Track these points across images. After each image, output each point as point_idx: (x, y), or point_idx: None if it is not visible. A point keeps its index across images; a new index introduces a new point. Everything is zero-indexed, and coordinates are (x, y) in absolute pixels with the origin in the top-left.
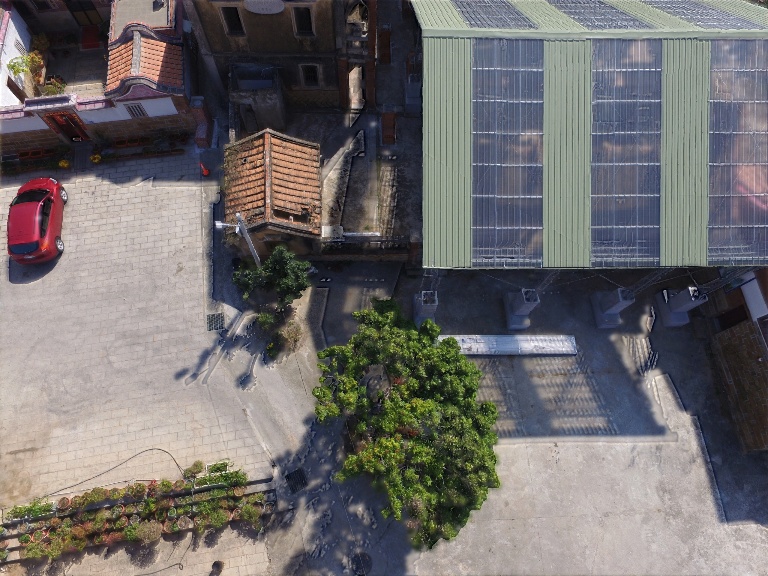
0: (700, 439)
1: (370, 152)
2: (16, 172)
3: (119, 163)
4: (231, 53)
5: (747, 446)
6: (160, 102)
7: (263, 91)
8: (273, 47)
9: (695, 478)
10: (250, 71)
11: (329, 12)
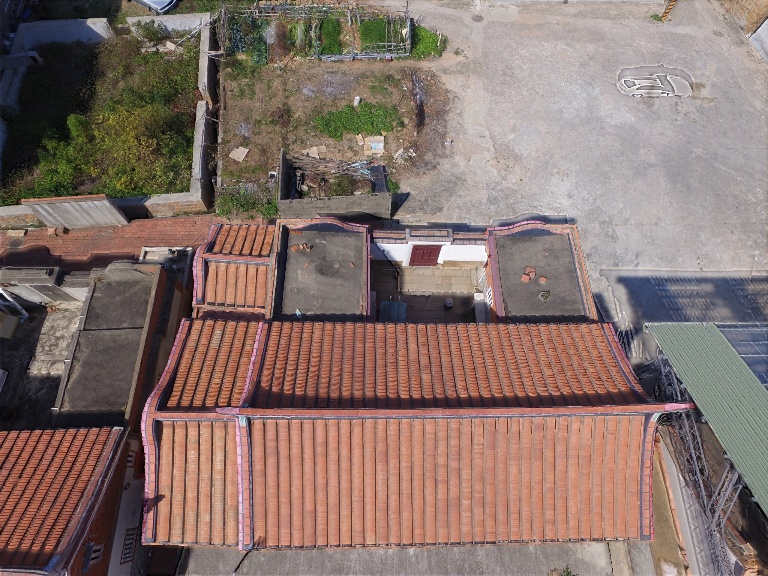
0: None
1: None
2: None
3: None
4: None
5: None
6: None
7: None
8: None
9: (588, 244)
10: None
11: None
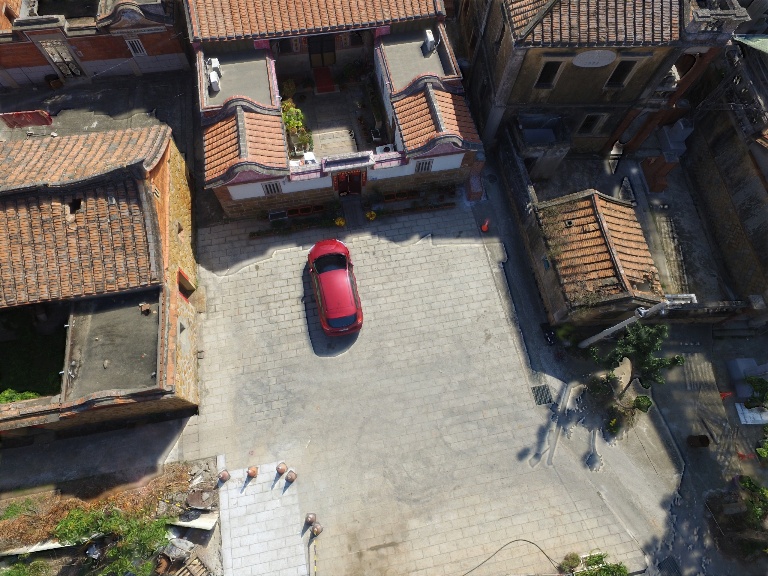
0: None
1: (641, 201)
2: (289, 232)
3: (391, 219)
4: (525, 104)
5: None
6: (452, 157)
7: (560, 144)
8: (572, 98)
9: None
10: (532, 121)
11: (656, 64)
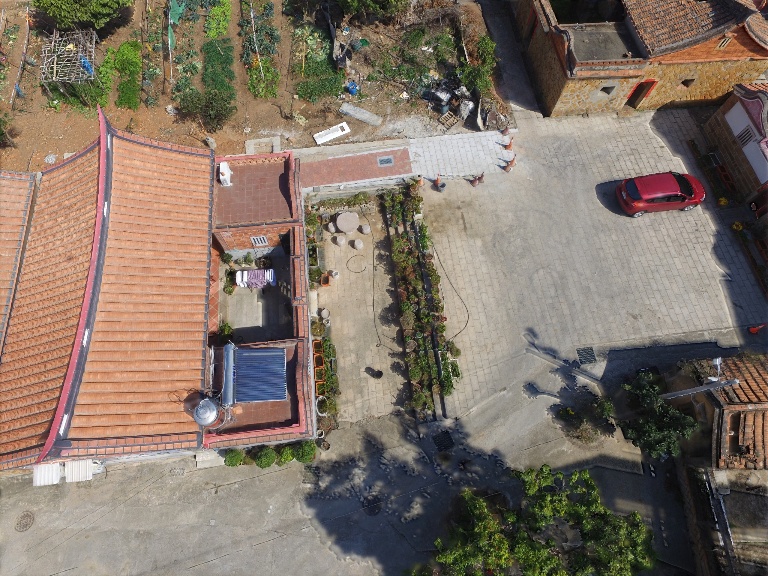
0: None
1: None
2: (702, 167)
3: (738, 246)
4: None
5: None
6: None
7: None
8: None
9: None
10: None
11: None
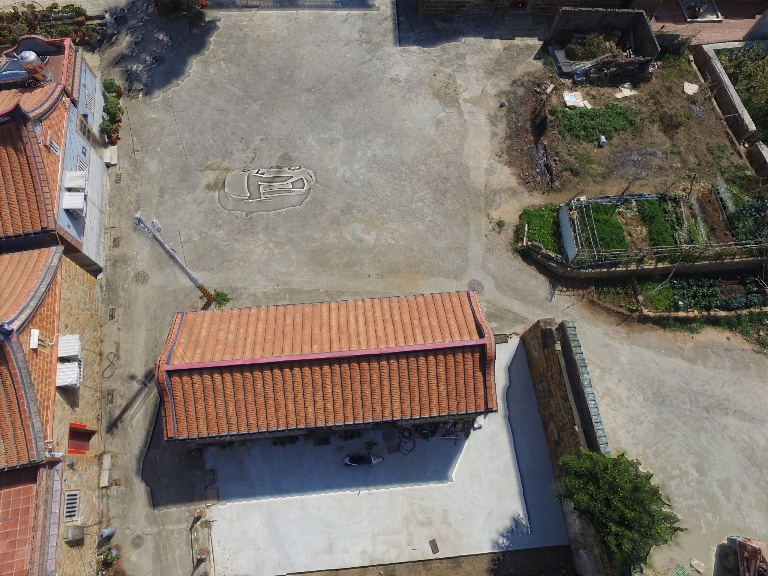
0: (394, 10)
1: None
2: None
3: None
4: None
5: (421, 9)
6: None
7: None
8: None
9: (385, 26)
10: None
11: None
